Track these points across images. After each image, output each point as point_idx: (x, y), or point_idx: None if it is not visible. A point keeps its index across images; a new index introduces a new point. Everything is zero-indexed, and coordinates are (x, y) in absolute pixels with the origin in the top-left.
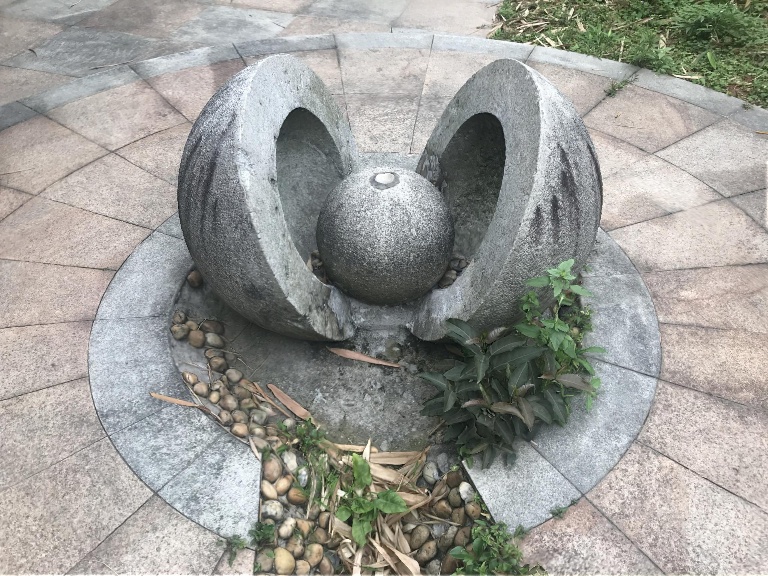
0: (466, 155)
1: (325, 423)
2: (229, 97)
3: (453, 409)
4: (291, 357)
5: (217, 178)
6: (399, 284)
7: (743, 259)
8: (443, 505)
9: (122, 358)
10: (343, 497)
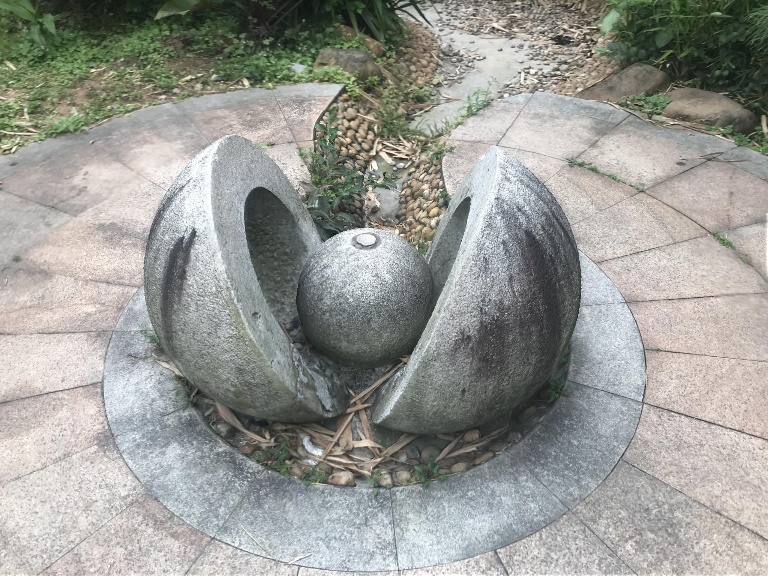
0: None
1: None
2: None
3: None
4: None
5: None
6: None
7: None
8: None
9: None
10: None
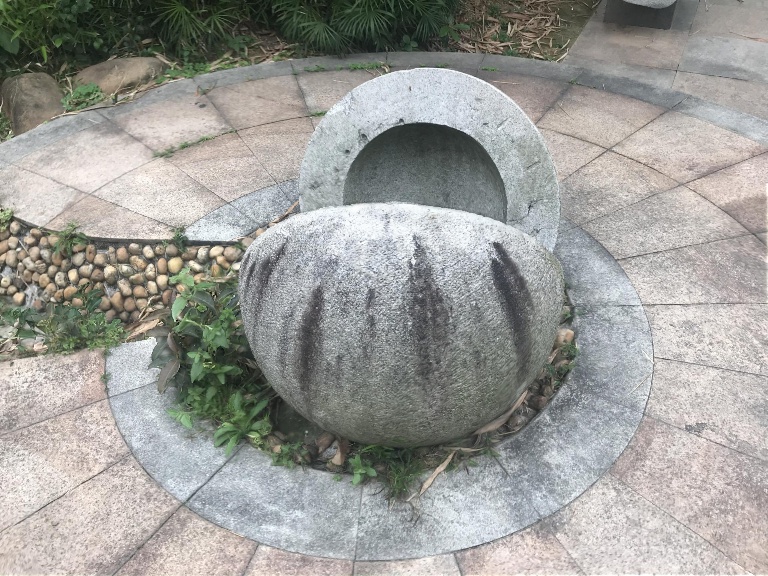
0: None
1: None
2: None
3: None
4: None
5: None
6: None
7: None
8: None
9: None
10: None
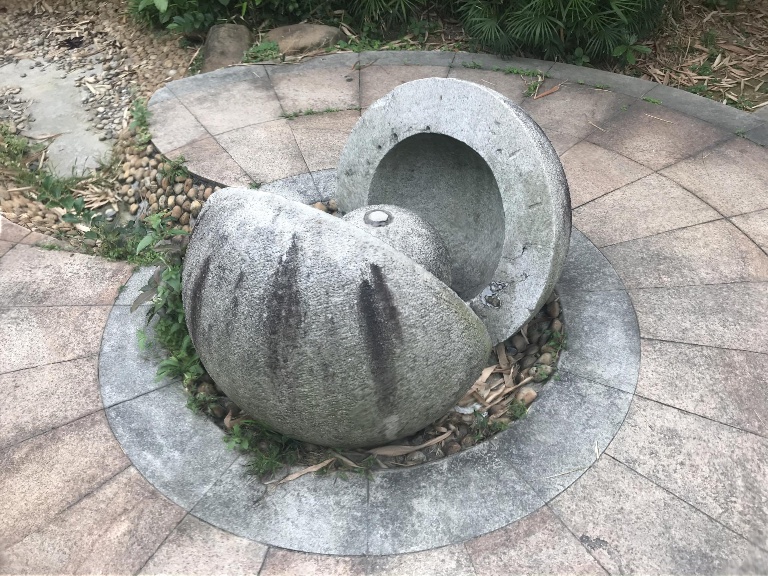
0: None
1: None
2: None
3: None
4: None
5: None
6: None
7: None
8: None
9: None
10: None
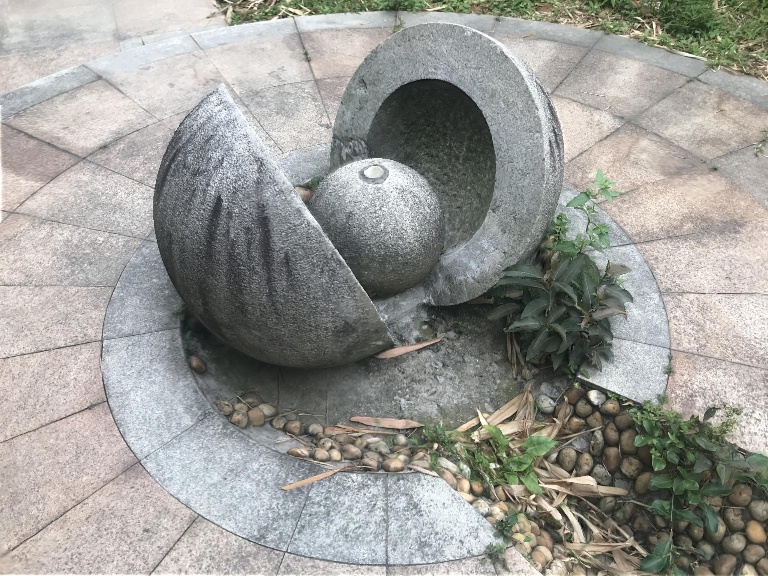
0: (388, 128)
1: (428, 420)
2: (230, 145)
3: (551, 340)
4: (349, 384)
5: (277, 231)
6: (428, 263)
7: (601, 134)
8: (576, 421)
9: (214, 477)
10: (496, 467)
